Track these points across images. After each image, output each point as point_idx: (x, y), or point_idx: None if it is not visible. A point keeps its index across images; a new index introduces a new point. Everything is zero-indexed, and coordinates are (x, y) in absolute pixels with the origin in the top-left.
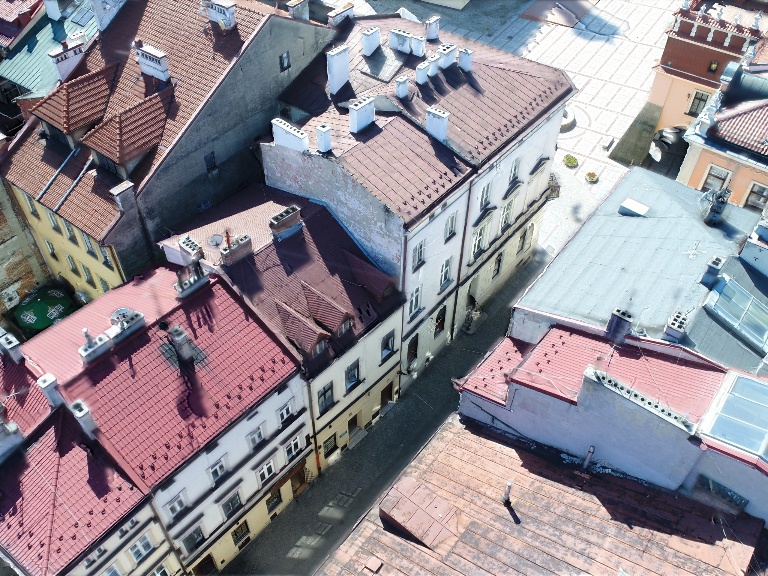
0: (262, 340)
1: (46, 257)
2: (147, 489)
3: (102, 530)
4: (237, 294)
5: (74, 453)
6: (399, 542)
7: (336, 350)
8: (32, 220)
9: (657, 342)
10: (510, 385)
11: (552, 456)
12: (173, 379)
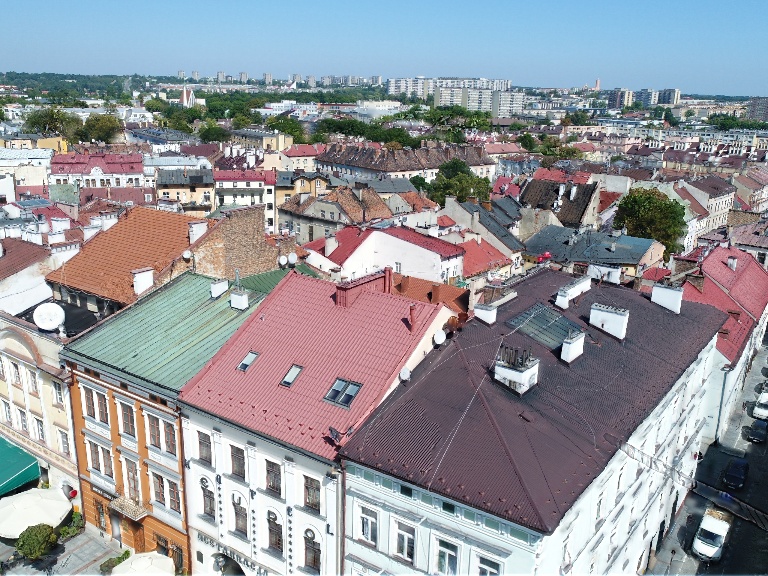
0: None
1: None
2: None
3: None
4: None
5: None
6: None
7: None
8: None
9: None
10: None
11: None
12: None
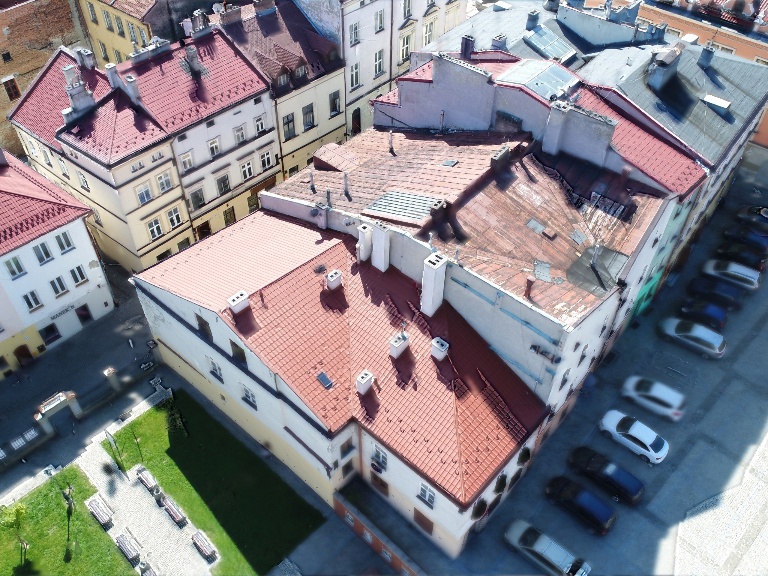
0: (245, 69)
1: (99, 63)
2: (170, 132)
3: (143, 146)
4: (230, 41)
5: (126, 111)
6: (324, 172)
7: (295, 85)
8: (92, 28)
9: (487, 51)
10: (398, 84)
11: (425, 132)
12: (187, 81)
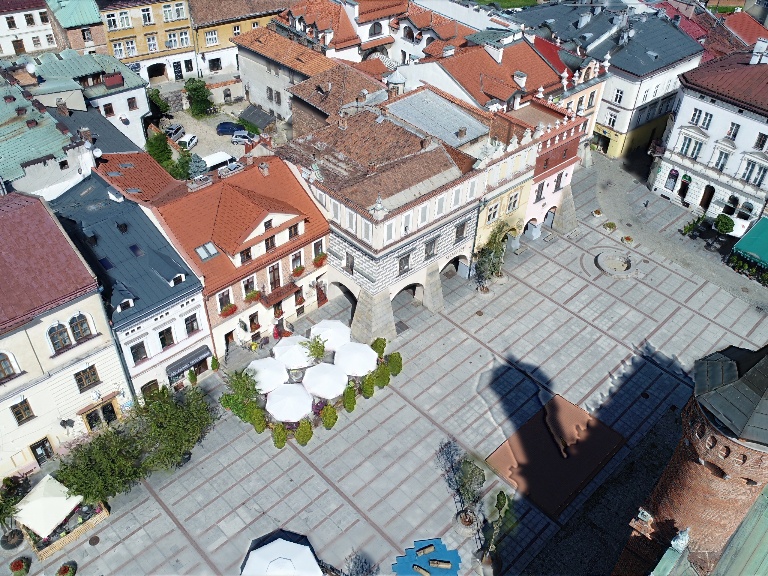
0: None
1: None
2: None
3: None
4: None
5: None
6: None
7: None
8: None
9: None
10: None
11: None
12: None
